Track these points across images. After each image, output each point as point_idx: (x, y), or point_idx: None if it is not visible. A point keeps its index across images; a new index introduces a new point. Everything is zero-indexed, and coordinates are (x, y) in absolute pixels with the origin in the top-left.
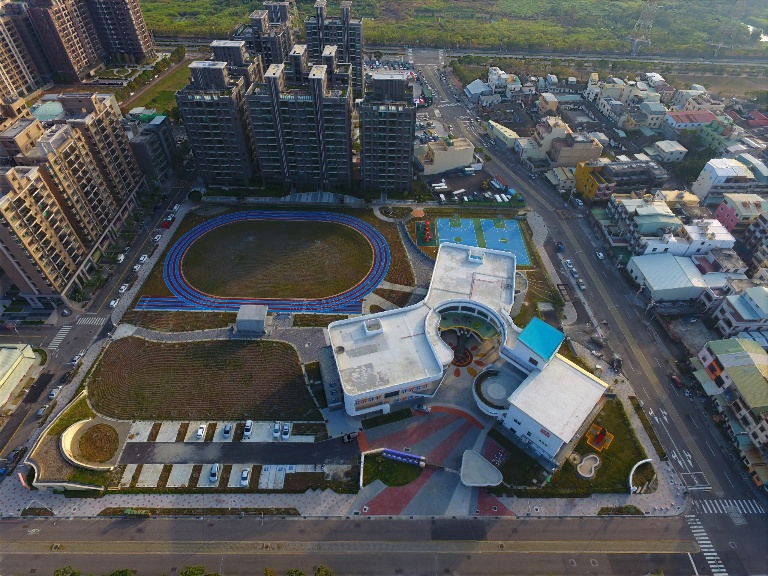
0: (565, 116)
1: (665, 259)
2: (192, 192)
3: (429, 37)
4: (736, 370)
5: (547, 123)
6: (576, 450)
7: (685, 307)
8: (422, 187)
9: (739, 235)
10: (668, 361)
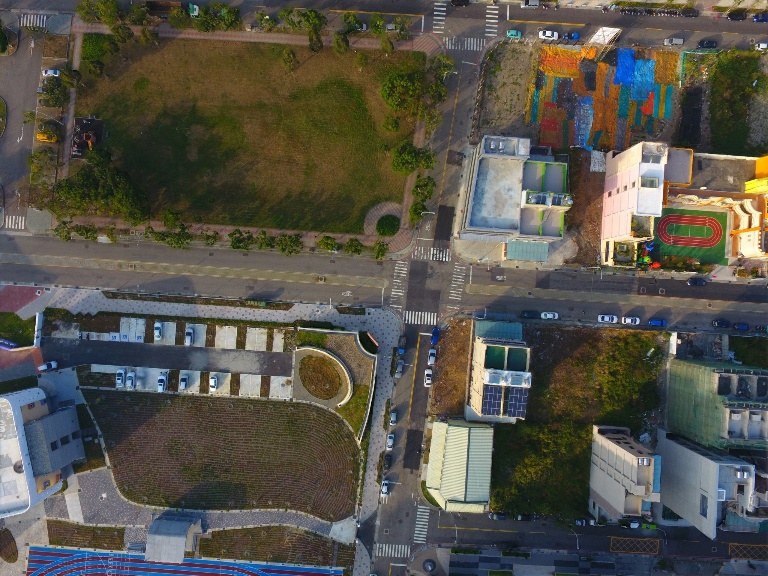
0: None
1: None
2: None
3: None
4: None
5: None
6: None
7: None
8: None
9: None
10: None
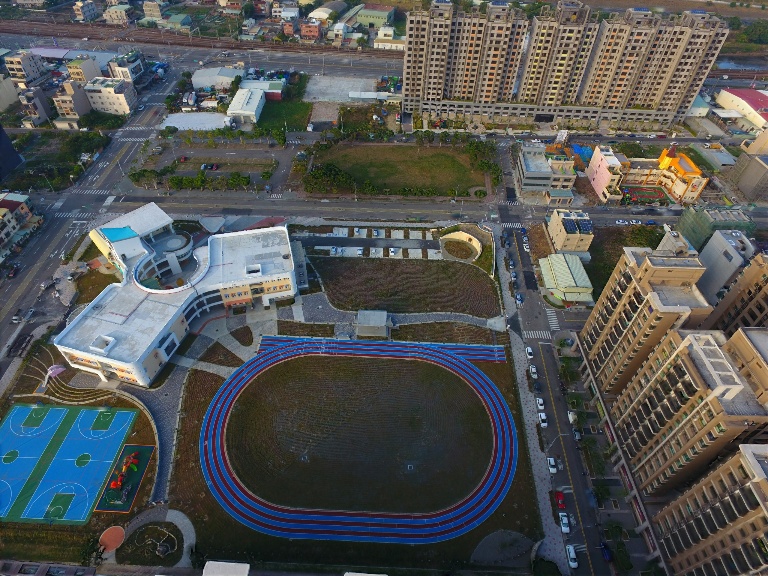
0: None
1: None
2: (553, 570)
3: None
4: None
5: None
6: None
7: None
8: None
9: None
10: None
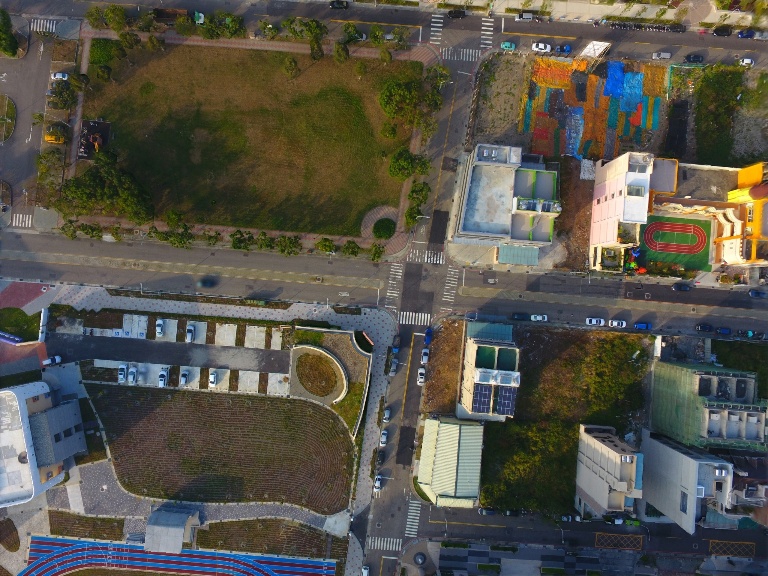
0: None
1: None
2: None
3: None
4: None
5: None
6: None
7: None
8: None
9: None
10: None
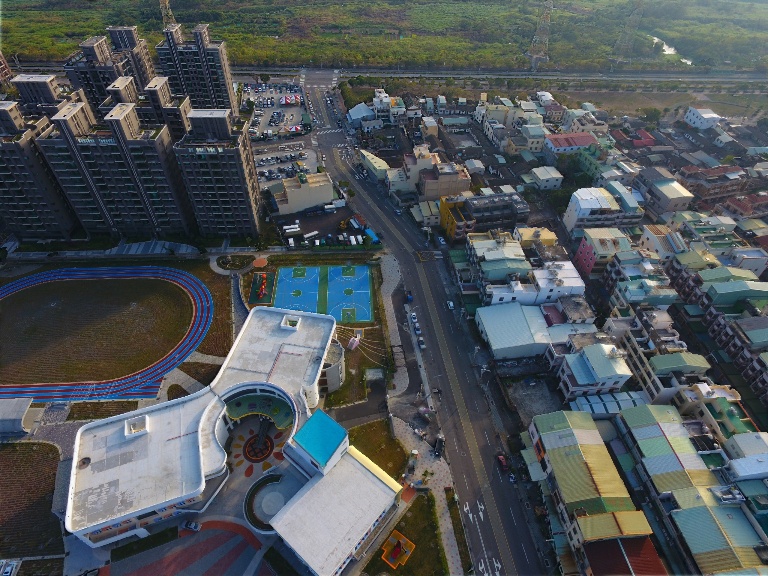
0: (446, 141)
1: (511, 310)
2: None
3: (324, 57)
4: (557, 453)
5: (414, 153)
6: (366, 570)
7: (530, 365)
8: (272, 230)
9: (600, 274)
10: (499, 436)
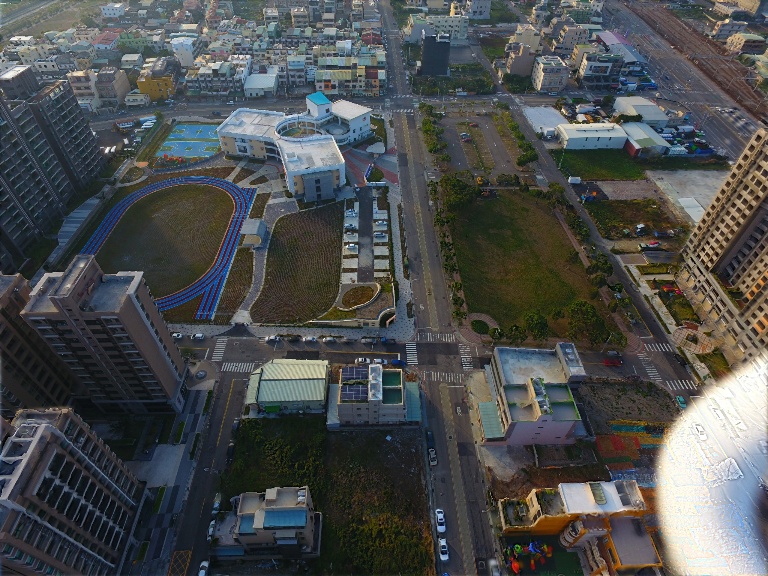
0: None
1: (251, 79)
2: None
3: None
4: (333, 77)
5: (74, 78)
6: None
7: (281, 89)
8: None
9: None
10: None
